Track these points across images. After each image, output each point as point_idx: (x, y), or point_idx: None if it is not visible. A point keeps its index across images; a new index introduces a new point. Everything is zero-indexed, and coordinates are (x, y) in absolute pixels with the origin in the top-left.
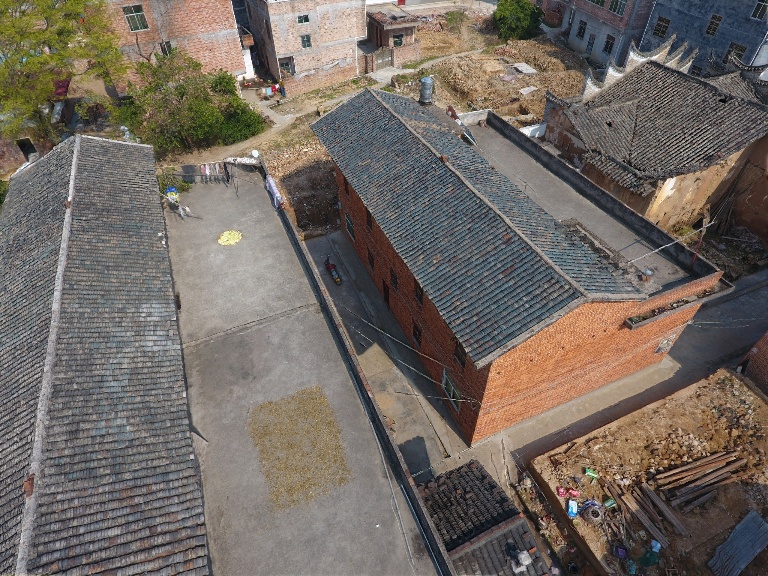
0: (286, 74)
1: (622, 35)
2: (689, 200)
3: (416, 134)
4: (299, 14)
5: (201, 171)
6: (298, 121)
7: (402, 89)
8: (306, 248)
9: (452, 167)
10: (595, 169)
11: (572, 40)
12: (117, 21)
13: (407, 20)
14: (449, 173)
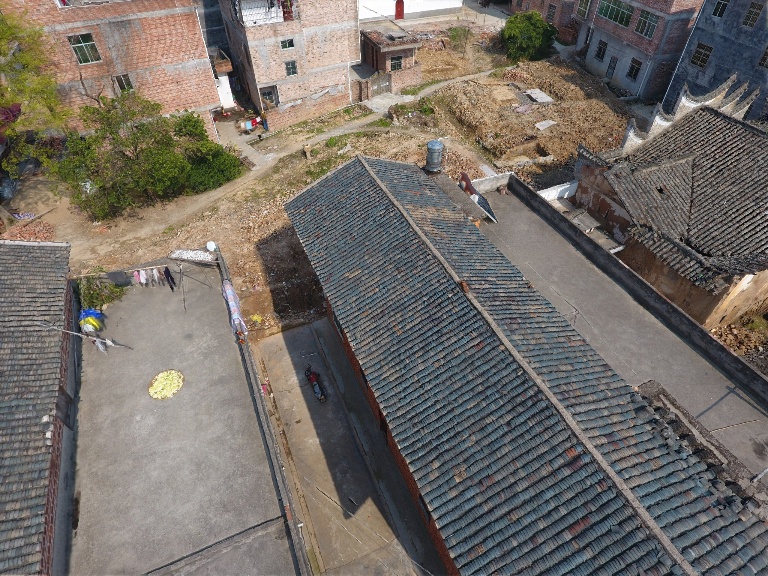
0: (269, 104)
1: (650, 60)
2: (764, 290)
3: (423, 237)
4: (282, 38)
5: (135, 277)
6: (281, 163)
7: (401, 122)
8: (284, 343)
9: (477, 302)
10: (643, 246)
11: (590, 61)
12: (62, 53)
13: (406, 41)
14: (473, 312)
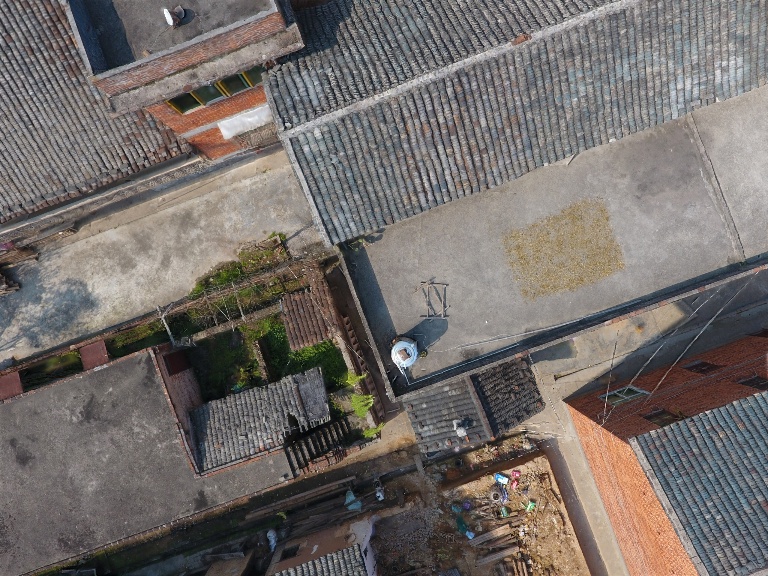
0: None
1: None
2: None
3: None
4: None
5: None
6: None
7: None
8: None
9: None
10: None
11: None
12: None
13: None
14: None
